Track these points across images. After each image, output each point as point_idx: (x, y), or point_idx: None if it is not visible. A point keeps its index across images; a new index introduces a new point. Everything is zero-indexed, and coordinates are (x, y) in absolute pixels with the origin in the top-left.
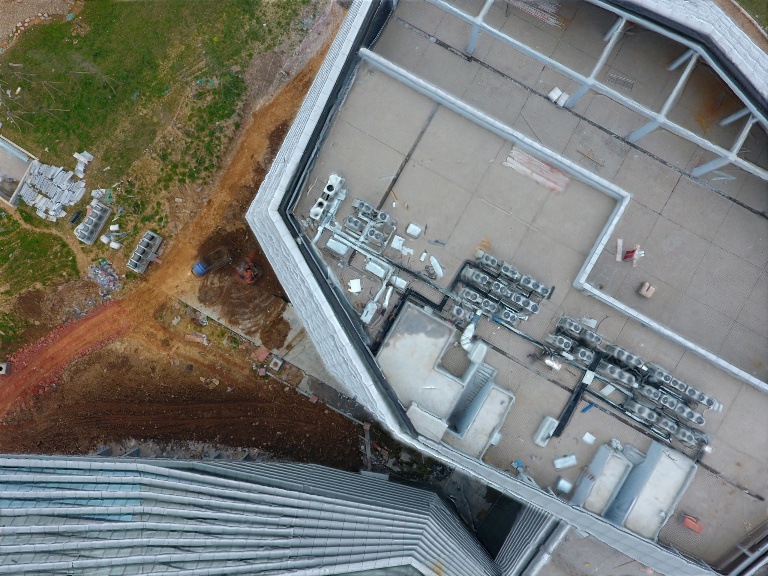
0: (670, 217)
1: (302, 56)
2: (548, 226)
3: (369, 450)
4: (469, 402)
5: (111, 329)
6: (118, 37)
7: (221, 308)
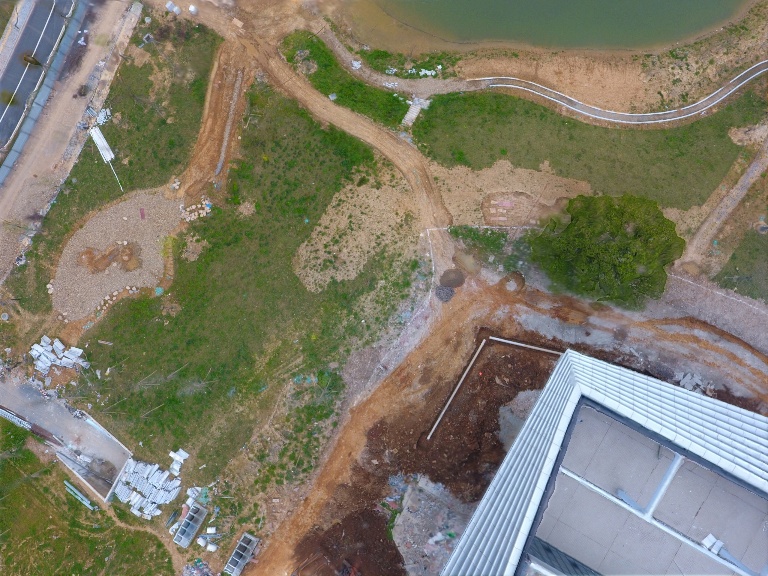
0: None
1: (400, 349)
2: None
3: None
4: None
5: None
6: (211, 324)
7: None
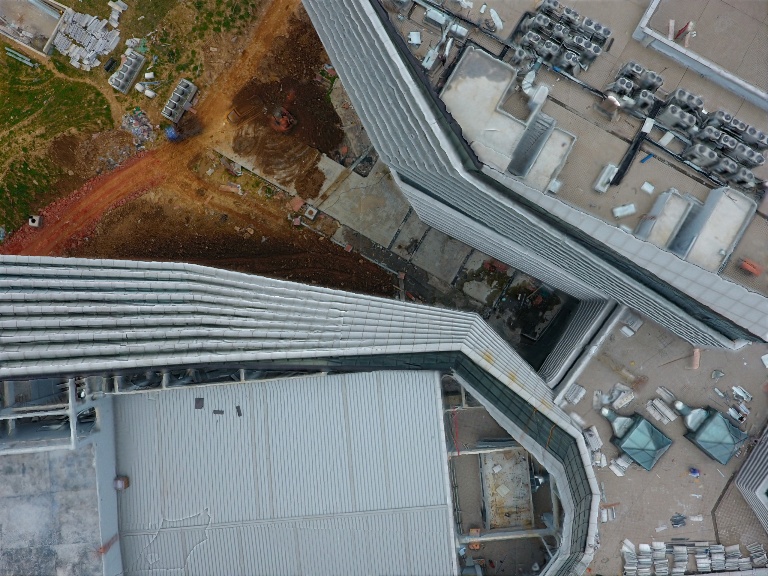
0: None
1: None
2: None
3: (403, 299)
4: (530, 145)
5: (145, 180)
6: None
7: (256, 158)
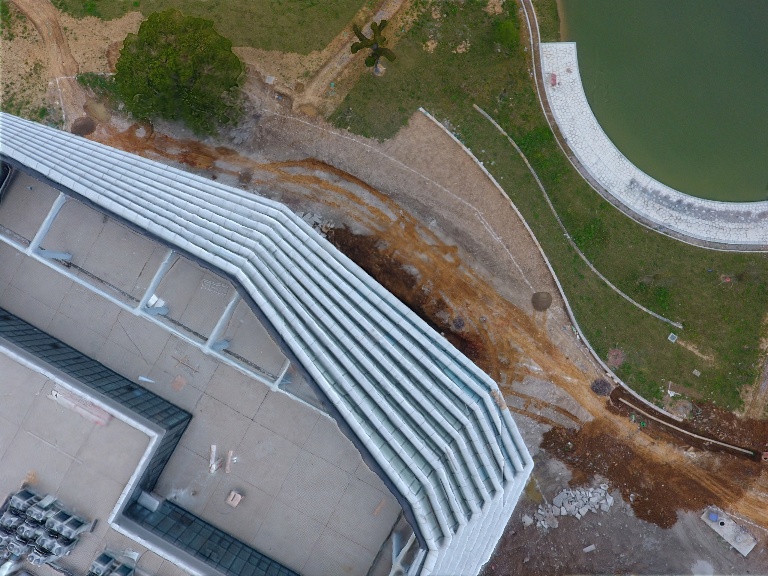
0: (262, 423)
1: None
2: (92, 459)
3: None
4: None
5: None
6: None
7: None
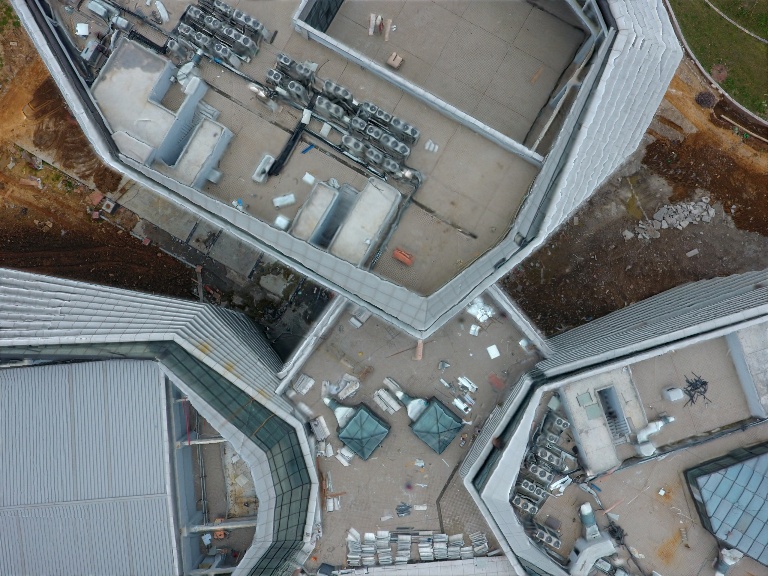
0: None
1: None
2: None
3: (201, 293)
4: (184, 135)
5: None
6: None
7: (56, 152)
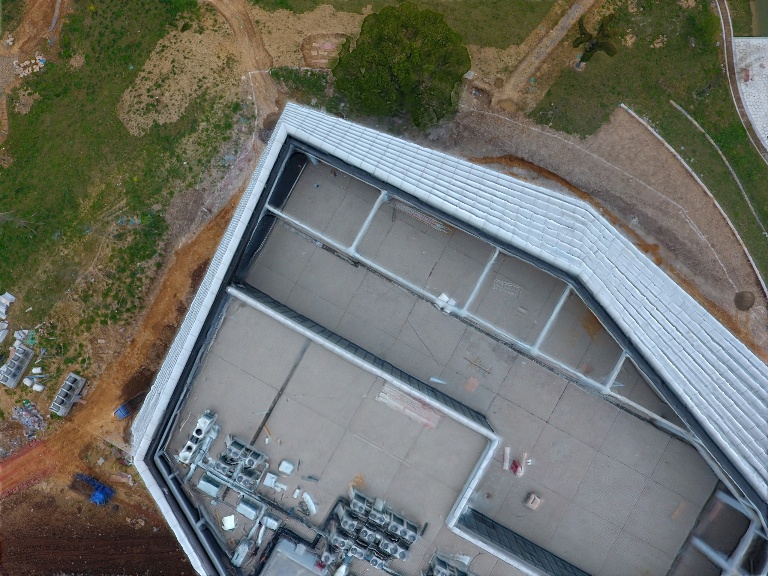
0: (557, 425)
1: (224, 192)
2: (421, 462)
3: None
4: None
5: (37, 469)
6: (40, 173)
7: None
